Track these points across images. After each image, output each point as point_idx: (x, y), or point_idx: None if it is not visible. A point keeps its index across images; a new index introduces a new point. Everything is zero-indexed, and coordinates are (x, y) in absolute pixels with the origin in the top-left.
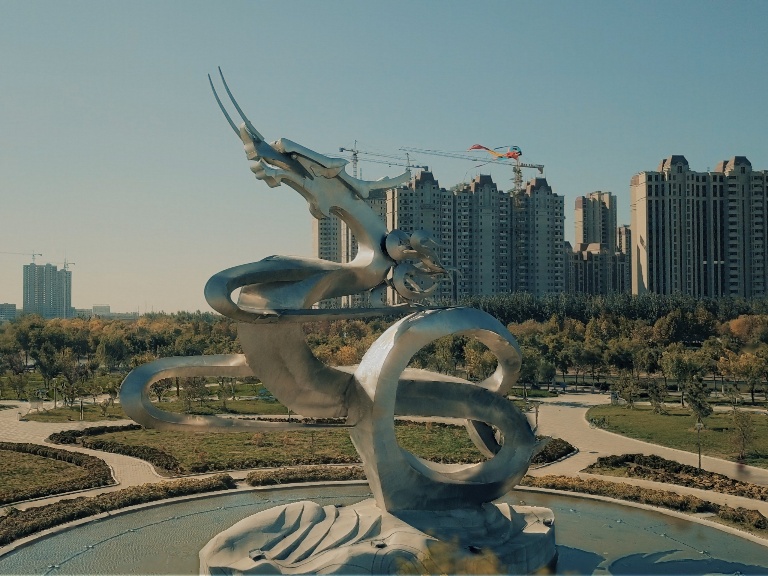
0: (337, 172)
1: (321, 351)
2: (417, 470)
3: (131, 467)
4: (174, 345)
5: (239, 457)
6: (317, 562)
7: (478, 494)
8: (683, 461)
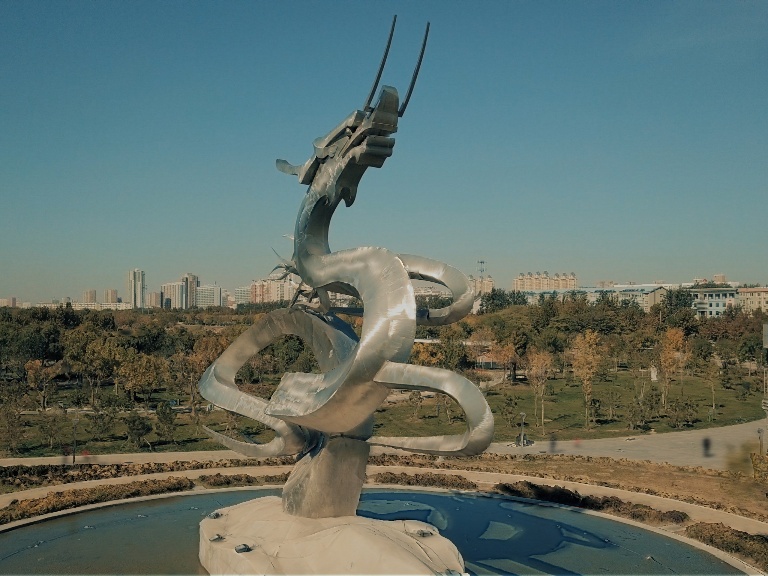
0: None
1: None
2: None
3: None
4: None
5: None
6: (450, 561)
7: None
8: None
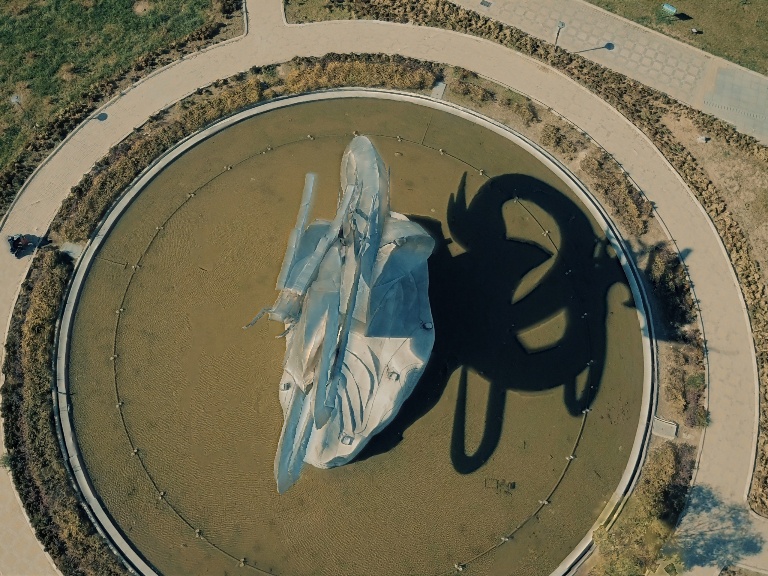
0: None
1: None
2: None
3: None
4: None
5: None
6: (375, 415)
7: None
8: None
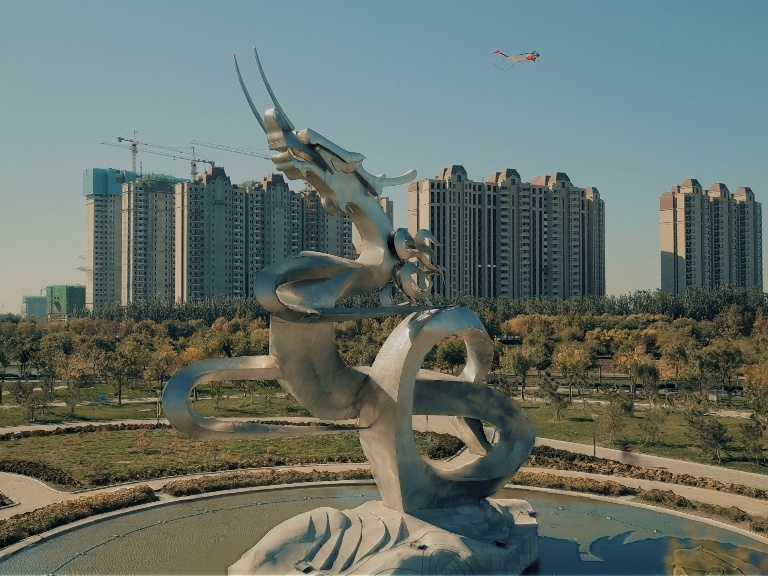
0: (355, 167)
1: (168, 352)
2: (430, 469)
3: (15, 484)
4: None
5: (134, 467)
6: (366, 569)
7: (480, 490)
8: None
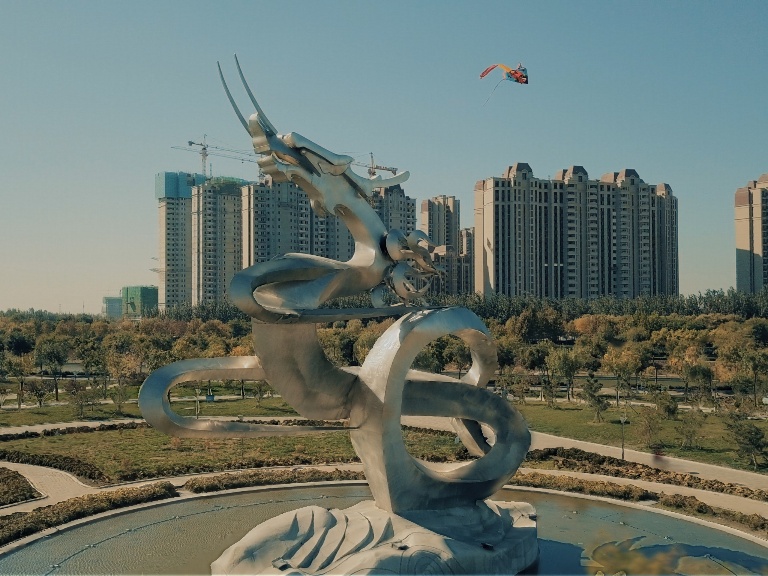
0: (343, 169)
1: (215, 351)
2: (421, 470)
3: (49, 478)
4: (53, 346)
5: (164, 463)
6: (343, 568)
7: (475, 492)
8: (599, 453)
